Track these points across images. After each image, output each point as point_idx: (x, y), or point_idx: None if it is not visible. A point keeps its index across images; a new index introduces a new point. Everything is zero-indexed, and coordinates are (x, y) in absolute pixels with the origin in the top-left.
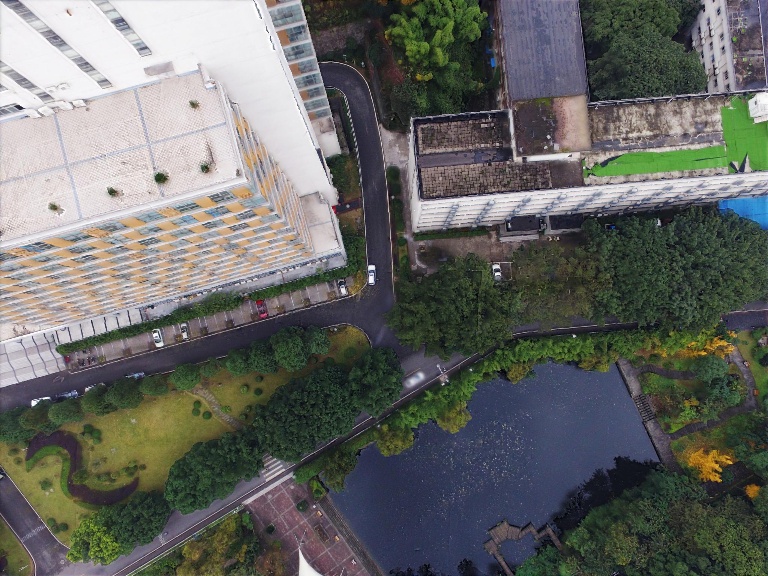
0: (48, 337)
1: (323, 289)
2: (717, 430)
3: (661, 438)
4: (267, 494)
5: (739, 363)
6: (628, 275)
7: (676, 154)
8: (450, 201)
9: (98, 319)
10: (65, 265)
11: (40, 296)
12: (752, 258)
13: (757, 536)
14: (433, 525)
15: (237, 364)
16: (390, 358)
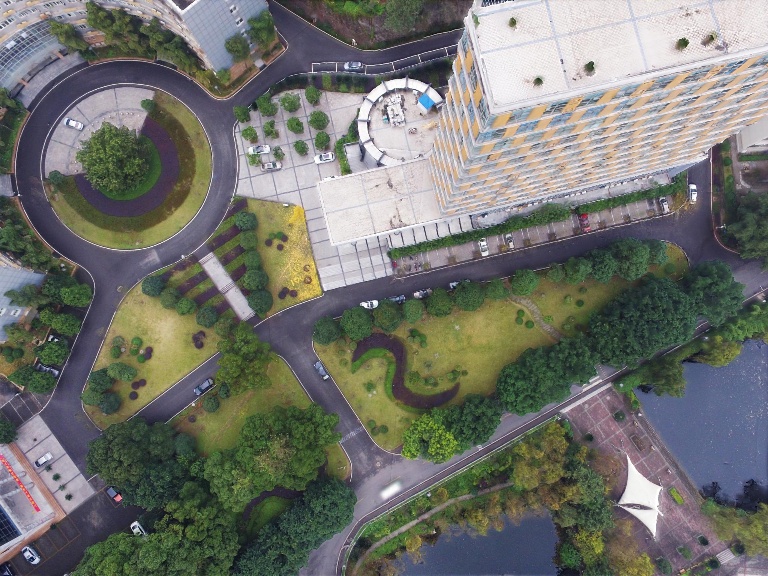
0: (381, 241)
1: (642, 206)
2: None
3: None
4: (584, 404)
5: None
6: None
7: None
8: None
9: (430, 225)
10: (665, 108)
11: (551, 158)
12: None
13: None
14: (741, 440)
15: (588, 268)
16: None
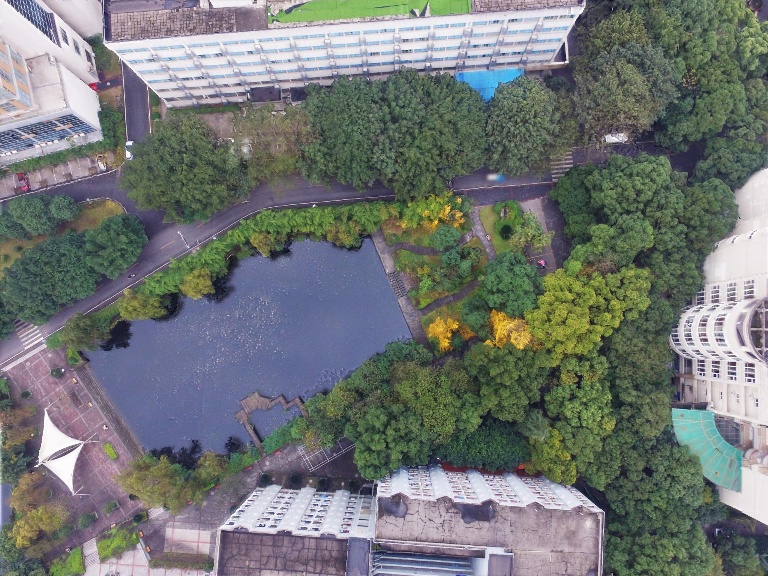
0: None
1: (85, 165)
2: (461, 303)
3: (413, 314)
4: (25, 361)
5: (482, 237)
6: (332, 129)
7: (359, 2)
8: (139, 46)
9: None
10: None
11: None
12: (451, 112)
13: (461, 389)
14: (187, 395)
15: None
16: (132, 224)
